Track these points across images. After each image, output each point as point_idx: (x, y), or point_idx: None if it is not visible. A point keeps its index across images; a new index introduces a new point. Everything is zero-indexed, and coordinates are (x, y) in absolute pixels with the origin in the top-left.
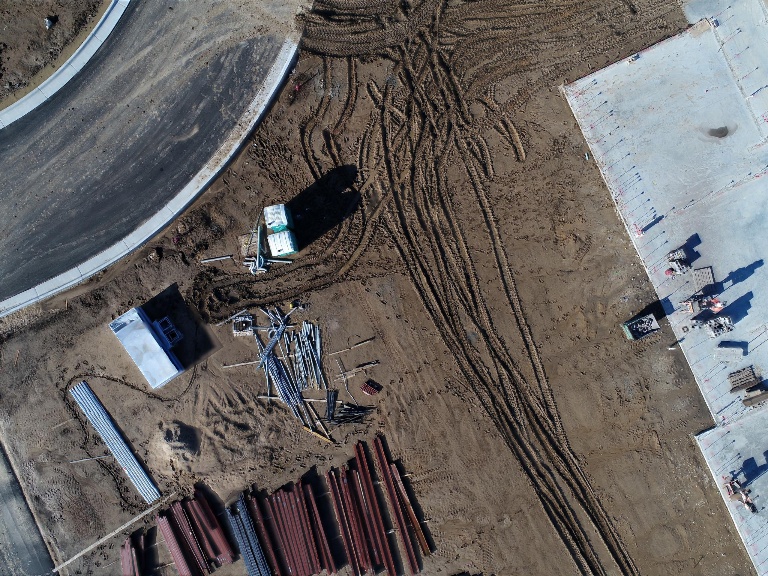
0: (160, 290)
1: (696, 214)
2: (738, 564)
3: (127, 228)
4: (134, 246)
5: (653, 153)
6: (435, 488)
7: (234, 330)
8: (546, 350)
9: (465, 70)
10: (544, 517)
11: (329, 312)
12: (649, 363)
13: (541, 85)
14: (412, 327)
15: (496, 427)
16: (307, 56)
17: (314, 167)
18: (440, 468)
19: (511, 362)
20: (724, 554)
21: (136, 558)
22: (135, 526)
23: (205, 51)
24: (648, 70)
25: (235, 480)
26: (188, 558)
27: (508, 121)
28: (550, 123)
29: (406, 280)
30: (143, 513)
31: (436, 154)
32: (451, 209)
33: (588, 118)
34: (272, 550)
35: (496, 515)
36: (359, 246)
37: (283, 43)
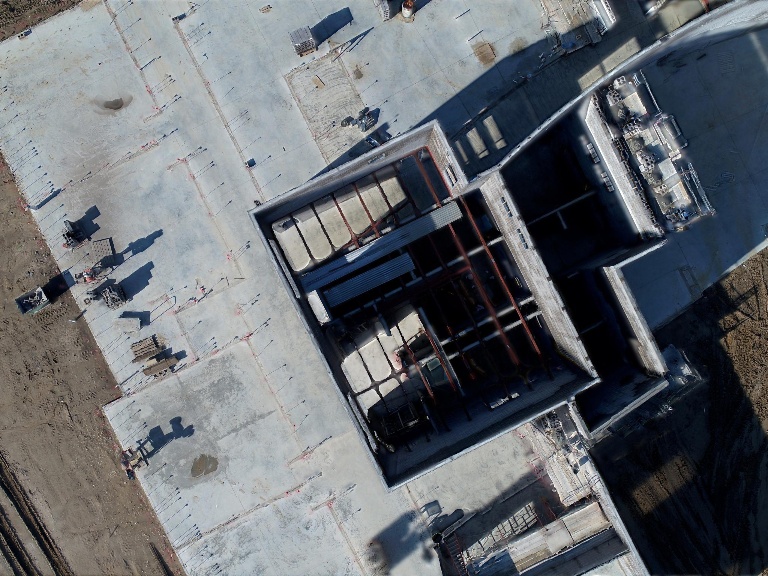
0: None
1: (94, 186)
2: (152, 532)
3: None
4: None
5: (49, 127)
6: None
7: None
8: None
9: None
10: None
11: None
12: (56, 336)
13: None
14: None
15: None
16: None
17: None
18: None
19: None
20: (137, 523)
21: None
22: None
23: None
24: (41, 45)
25: None
26: None
27: None
28: None
29: None
30: None
31: None
32: None
33: None
34: None
35: None
36: None
37: None
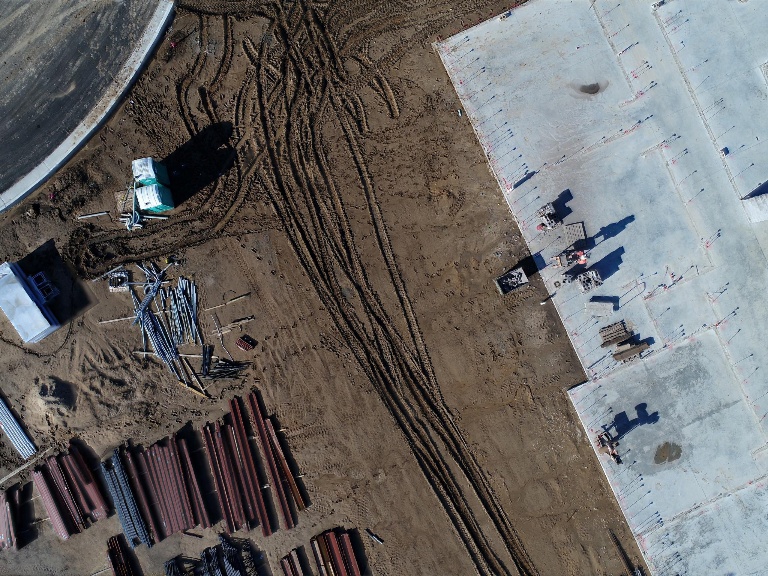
0: (37, 246)
1: (568, 170)
2: (611, 518)
3: (4, 184)
4: (10, 202)
5: (525, 109)
6: (310, 443)
7: (110, 286)
8: (420, 305)
9: (340, 27)
10: (418, 472)
11: (205, 268)
12: (522, 318)
13: (415, 42)
14: (287, 283)
15: (371, 382)
16: (183, 14)
17: (190, 124)
18: (315, 423)
19: (385, 317)
20: (597, 508)
21: (10, 512)
22: (11, 481)
23: (82, 9)
24: (520, 27)
25: (111, 435)
26: (63, 513)
27: (382, 78)
28: (423, 80)
29: (281, 236)
30: (19, 468)
31: (311, 111)
32: (326, 165)
33: (460, 75)
34: (147, 505)
35: (371, 470)
36: (235, 202)
37: (159, 1)
